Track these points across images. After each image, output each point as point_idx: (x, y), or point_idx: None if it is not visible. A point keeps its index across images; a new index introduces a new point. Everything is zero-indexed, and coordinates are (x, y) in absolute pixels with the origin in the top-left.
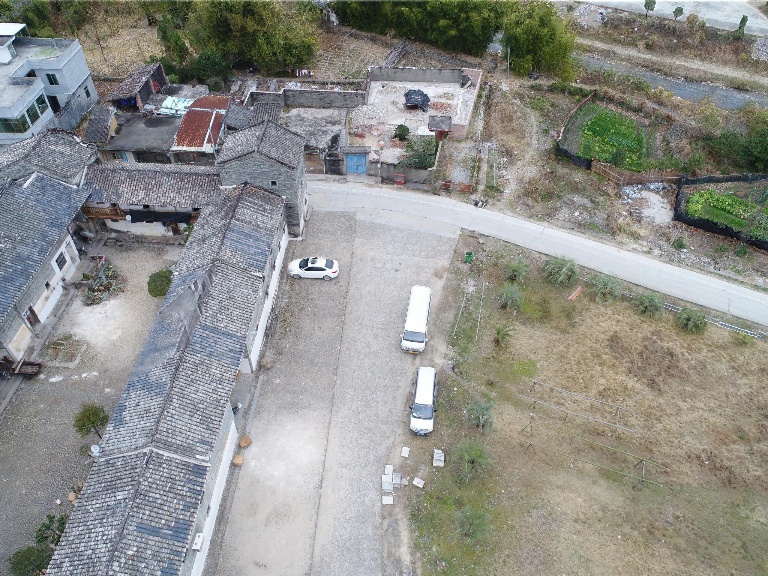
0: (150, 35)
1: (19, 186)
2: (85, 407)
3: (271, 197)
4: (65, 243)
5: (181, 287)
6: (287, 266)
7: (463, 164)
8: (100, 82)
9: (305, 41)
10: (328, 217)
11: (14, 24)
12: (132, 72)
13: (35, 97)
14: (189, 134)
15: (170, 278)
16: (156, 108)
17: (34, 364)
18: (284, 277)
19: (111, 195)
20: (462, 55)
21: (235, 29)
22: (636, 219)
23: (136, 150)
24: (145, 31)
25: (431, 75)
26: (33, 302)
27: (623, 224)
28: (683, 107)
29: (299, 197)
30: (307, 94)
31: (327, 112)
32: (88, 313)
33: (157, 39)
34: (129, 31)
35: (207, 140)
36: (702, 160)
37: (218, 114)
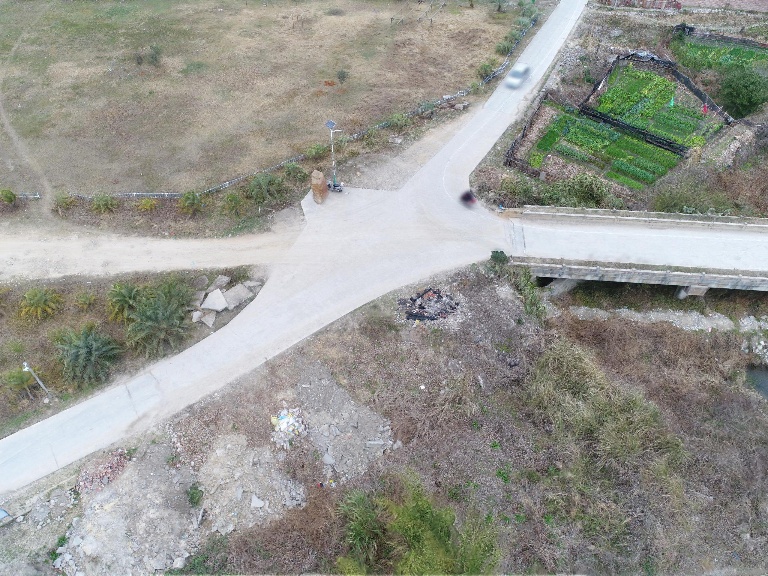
0: None
1: None
2: None
3: None
4: None
5: None
6: None
7: None
8: None
9: None
10: None
11: None
12: None
13: None
14: None
15: None
16: None
17: None
18: None
19: None
20: None
21: None
22: None
23: None
24: None
25: None
26: None
27: None
28: None
29: None
30: None
31: None
32: None
33: None
34: None
35: None
36: (697, 63)
37: None
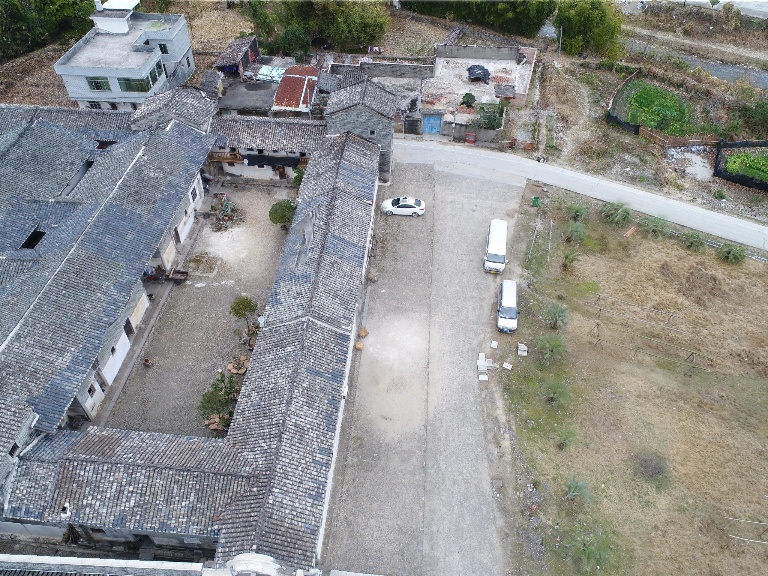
0: (230, 16)
1: (163, 129)
2: (228, 305)
3: (369, 145)
4: (197, 179)
5: (307, 209)
6: (380, 205)
7: (524, 128)
8: (193, 55)
9: (378, 20)
10: (410, 168)
11: (130, 0)
12: (231, 44)
13: (155, 62)
14: (286, 96)
15: (289, 208)
16: (254, 75)
17: (182, 272)
18: (378, 214)
19: (233, 141)
20: (516, 36)
21: (318, 8)
22: (680, 175)
23: (242, 109)
24: (225, 13)
25: (490, 53)
26: (177, 224)
27: (669, 178)
28: (720, 84)
29: (391, 146)
30: (381, 67)
31: (404, 80)
32: (218, 237)
33: (236, 20)
34: (210, 13)
35: (302, 102)
36: (739, 126)
37: (310, 80)
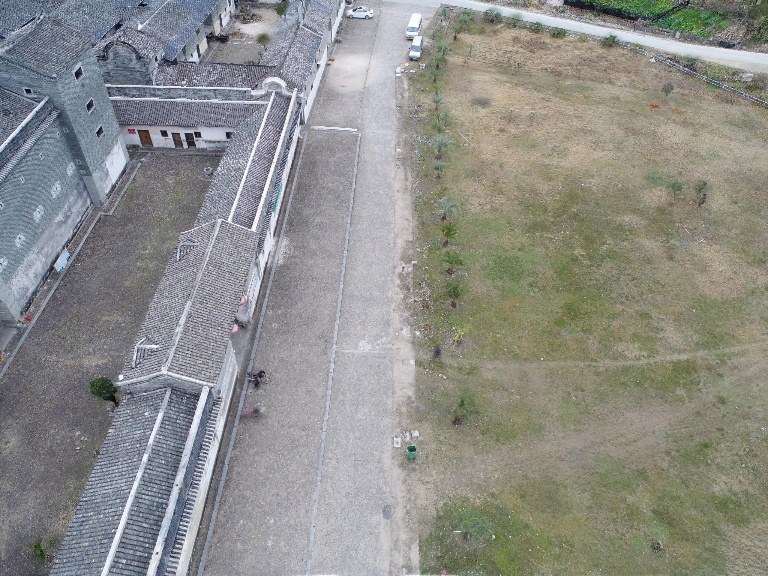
0: None
1: None
2: (253, 50)
3: None
4: None
5: None
6: None
7: None
8: None
9: None
10: None
11: None
12: None
13: None
14: None
15: (289, 5)
16: None
17: (225, 36)
18: (344, 18)
19: None
20: None
21: None
22: (542, 3)
23: None
24: None
25: None
26: (221, 12)
27: None
28: None
29: None
30: None
31: None
32: (245, 26)
33: None
34: None
35: None
36: None
37: None
